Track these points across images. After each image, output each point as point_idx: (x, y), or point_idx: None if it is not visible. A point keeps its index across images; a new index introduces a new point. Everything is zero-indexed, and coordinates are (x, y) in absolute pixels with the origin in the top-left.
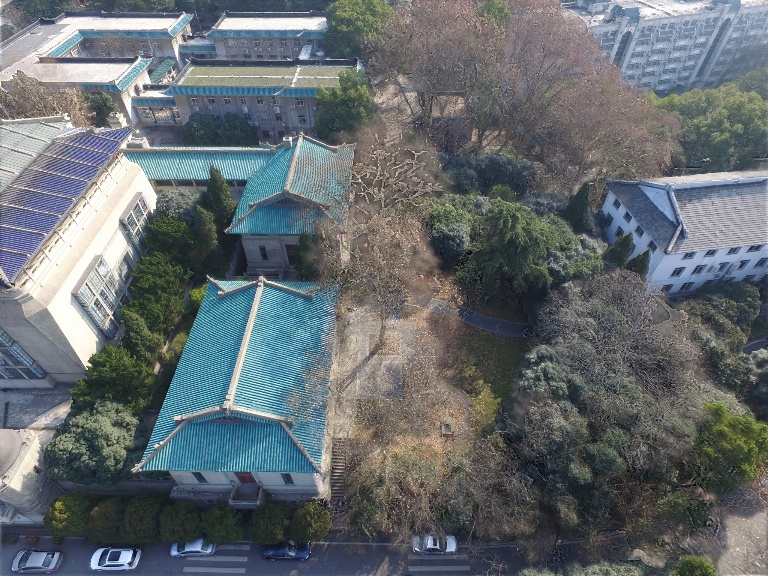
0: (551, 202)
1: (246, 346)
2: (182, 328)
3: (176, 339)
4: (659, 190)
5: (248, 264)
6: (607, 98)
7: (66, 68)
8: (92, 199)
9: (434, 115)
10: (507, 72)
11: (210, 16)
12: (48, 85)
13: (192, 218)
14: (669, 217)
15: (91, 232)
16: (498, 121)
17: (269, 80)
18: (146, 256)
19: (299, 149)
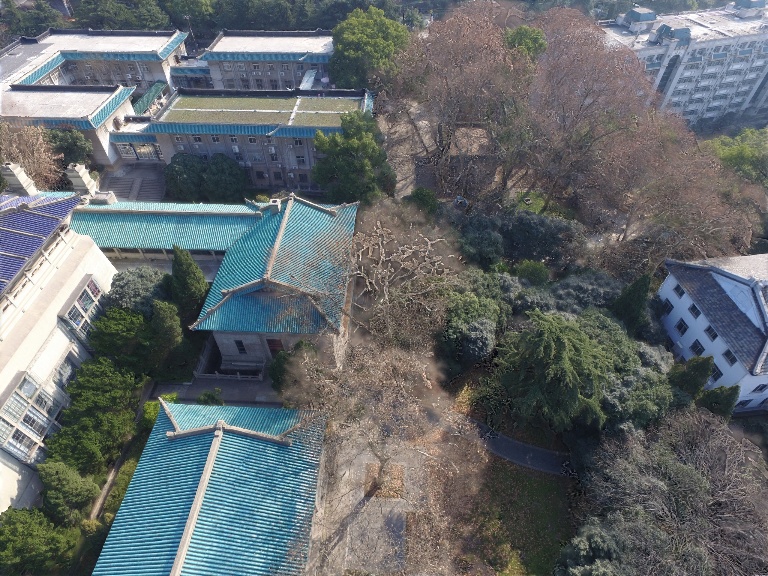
0: (597, 288)
1: (188, 543)
2: (133, 451)
3: (123, 469)
4: (740, 284)
5: (222, 357)
6: (666, 153)
7: (39, 98)
8: (18, 297)
9: (452, 152)
10: (544, 121)
11: (209, 32)
12: (14, 120)
13: (151, 308)
14: (754, 322)
15: (13, 342)
16: (525, 157)
17: (264, 115)
18: (88, 364)
19: (288, 216)
